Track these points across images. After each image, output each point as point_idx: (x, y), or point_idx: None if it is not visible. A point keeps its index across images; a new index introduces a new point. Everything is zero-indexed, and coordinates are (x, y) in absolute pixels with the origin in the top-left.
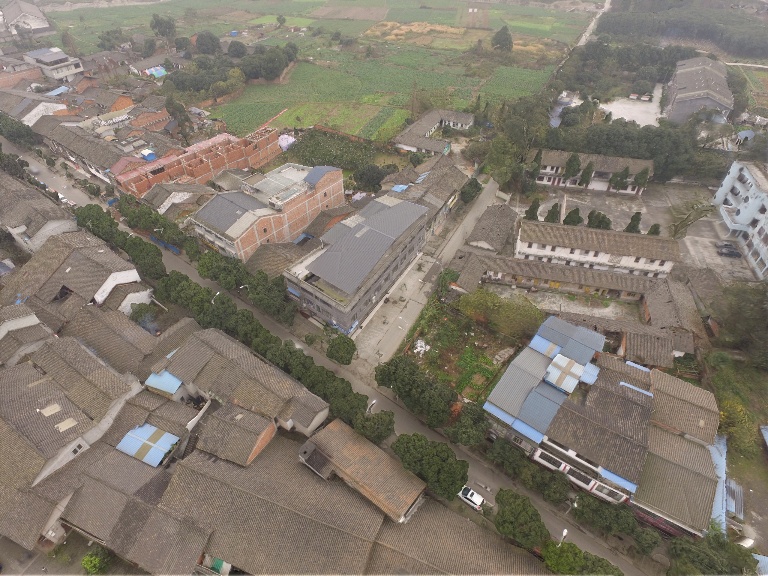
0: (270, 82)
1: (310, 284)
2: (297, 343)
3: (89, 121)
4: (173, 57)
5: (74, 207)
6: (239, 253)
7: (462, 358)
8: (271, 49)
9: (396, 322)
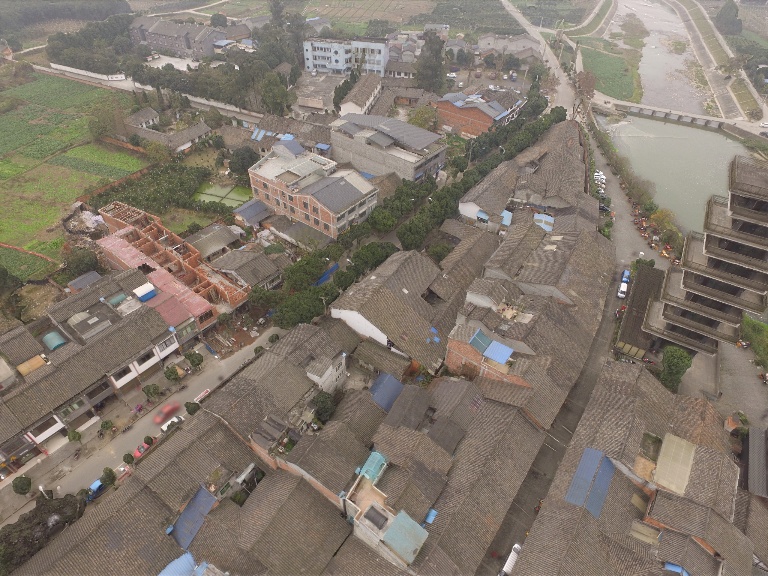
0: None
1: None
2: None
3: None
4: None
5: None
6: None
7: None
8: None
9: None
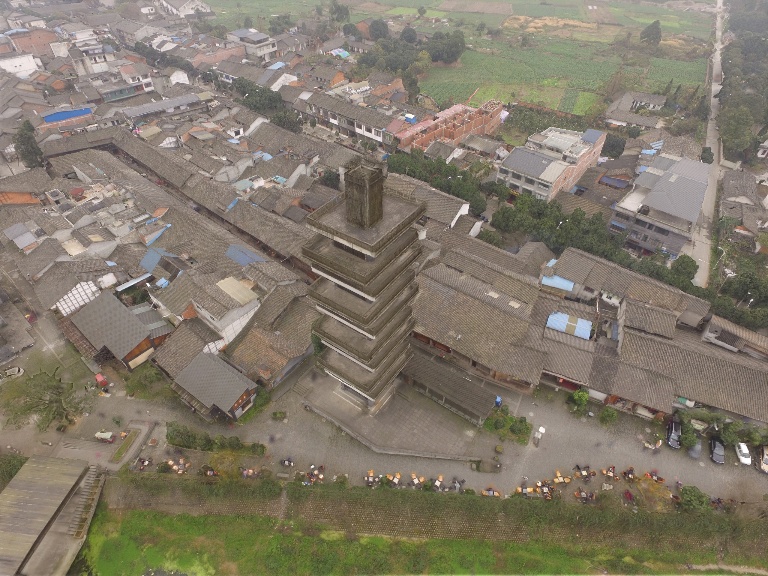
0: (447, 65)
1: None
2: None
3: (337, 90)
4: (349, 41)
5: None
6: (549, 195)
7: None
8: (456, 34)
9: (694, 256)
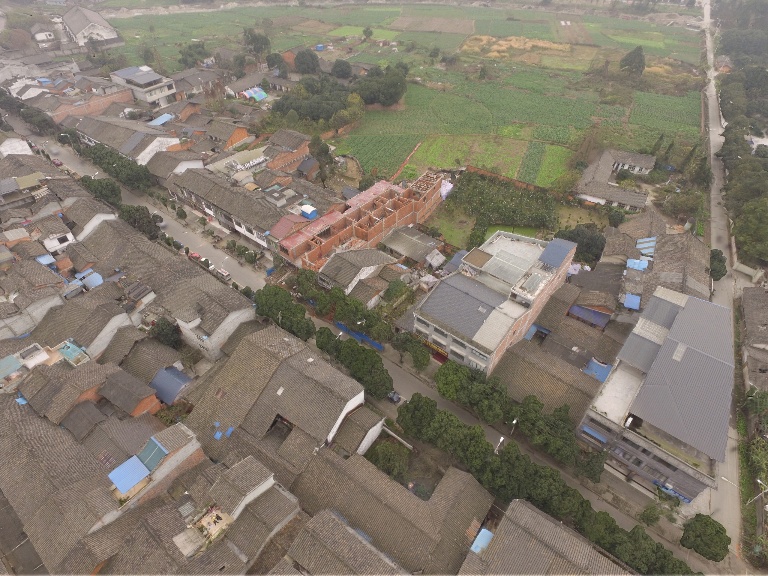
0: (386, 108)
1: (636, 433)
2: (599, 504)
3: (221, 163)
4: (269, 77)
5: (227, 277)
6: (489, 366)
7: None
8: (394, 72)
9: None
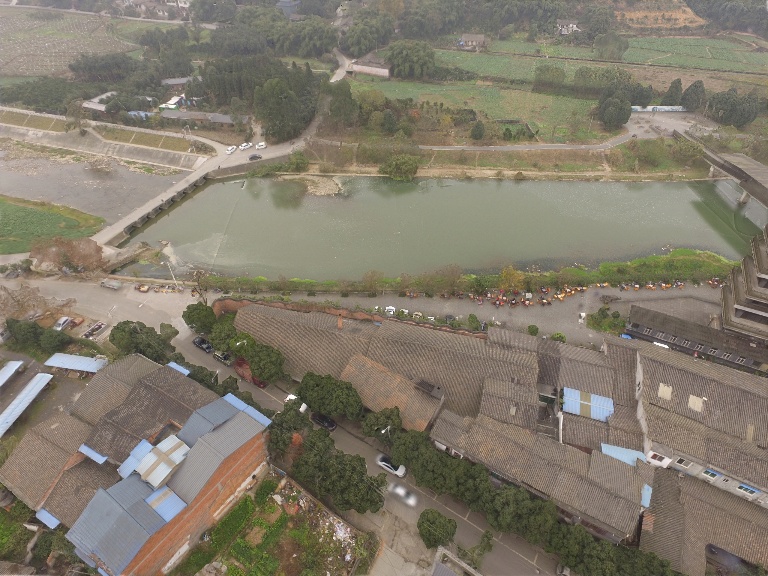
0: None
1: None
2: None
3: None
4: None
5: None
6: None
7: (269, 575)
8: None
9: None
